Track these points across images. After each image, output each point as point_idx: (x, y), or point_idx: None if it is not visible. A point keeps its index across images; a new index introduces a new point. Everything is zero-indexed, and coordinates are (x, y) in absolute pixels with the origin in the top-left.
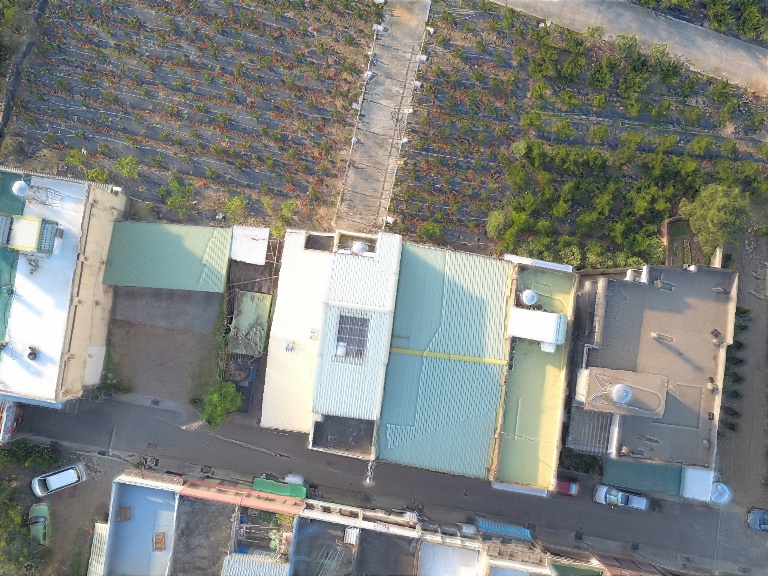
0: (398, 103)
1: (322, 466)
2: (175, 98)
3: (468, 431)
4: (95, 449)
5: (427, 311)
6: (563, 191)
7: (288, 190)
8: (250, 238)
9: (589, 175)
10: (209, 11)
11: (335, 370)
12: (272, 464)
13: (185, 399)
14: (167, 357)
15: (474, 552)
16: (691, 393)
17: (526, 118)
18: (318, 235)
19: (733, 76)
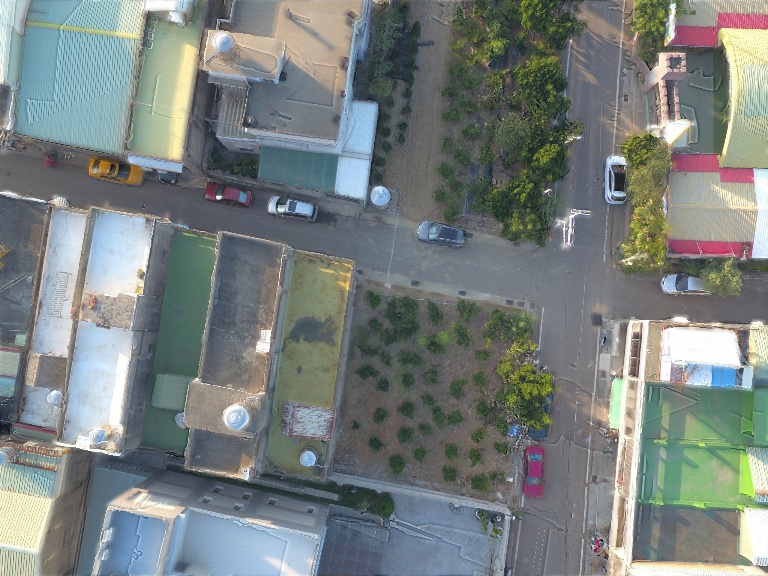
0: None
1: (2, 177)
2: None
3: (106, 106)
4: None
5: None
6: None
7: None
8: None
9: None
10: None
11: None
12: None
13: None
14: None
15: None
16: (326, 72)
17: None
18: None
19: None
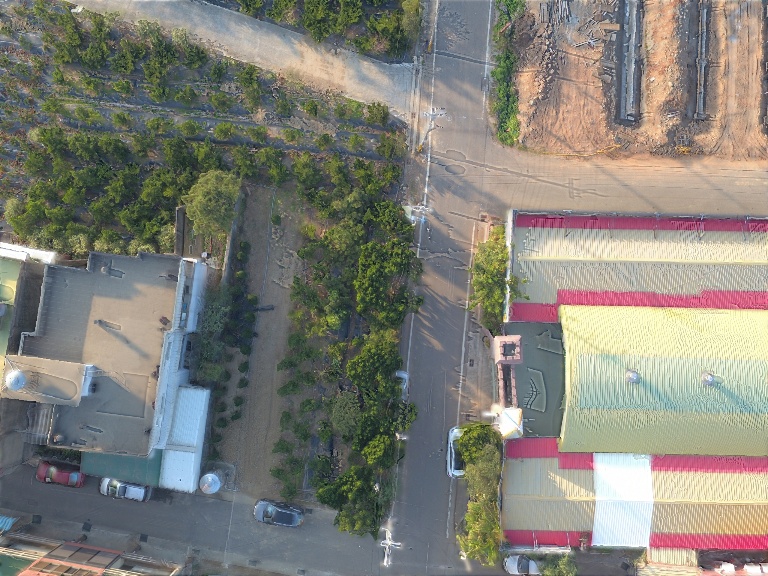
0: None
1: None
2: None
3: None
4: None
5: None
6: None
7: None
8: None
9: (116, 162)
10: None
11: None
12: None
13: None
14: None
15: None
16: (137, 382)
17: (44, 104)
18: None
19: (267, 62)
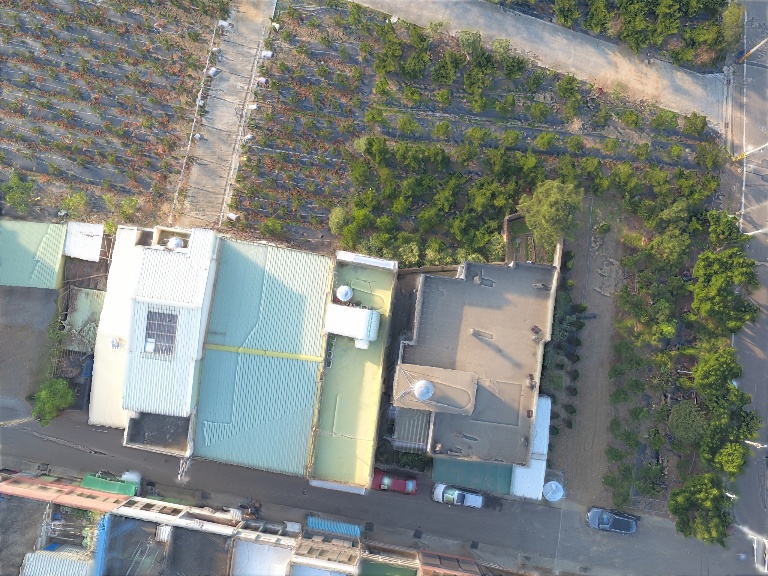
0: (242, 99)
1: (159, 464)
2: (19, 94)
3: (285, 428)
4: None
5: (245, 307)
6: (403, 187)
7: (131, 186)
8: (85, 234)
9: (434, 171)
10: (55, 7)
11: (144, 366)
12: (109, 462)
13: (23, 396)
14: (5, 354)
15: (290, 550)
16: (511, 390)
17: (368, 114)
18: (152, 231)
19: (581, 72)
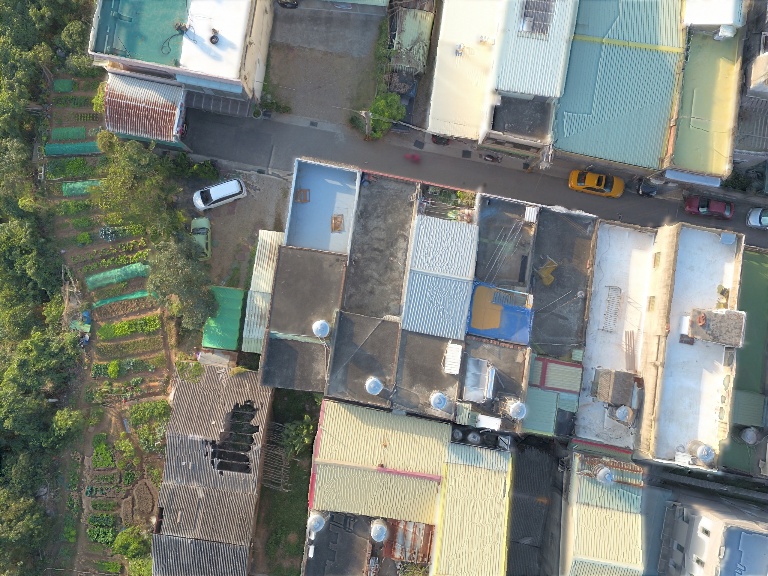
0: None
1: (479, 187)
2: None
3: (644, 120)
4: (254, 168)
5: (605, 2)
6: None
7: None
8: None
9: None
10: None
11: (521, 45)
12: None
13: (344, 120)
14: (326, 79)
15: (650, 237)
16: None
17: None
18: None
19: None
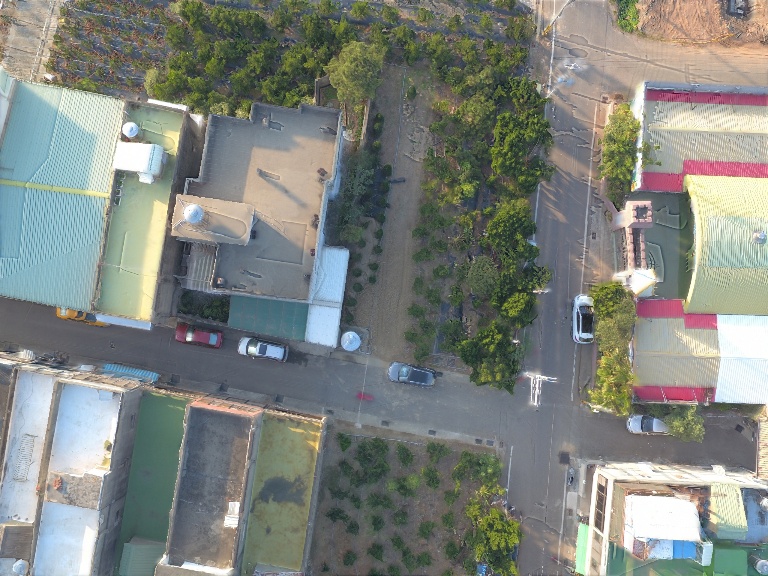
0: None
1: None
2: None
3: (73, 264)
4: None
5: (35, 145)
6: (216, 49)
7: None
8: None
9: (252, 38)
10: None
11: None
12: None
13: None
14: None
15: None
16: (296, 230)
17: None
18: None
19: None
